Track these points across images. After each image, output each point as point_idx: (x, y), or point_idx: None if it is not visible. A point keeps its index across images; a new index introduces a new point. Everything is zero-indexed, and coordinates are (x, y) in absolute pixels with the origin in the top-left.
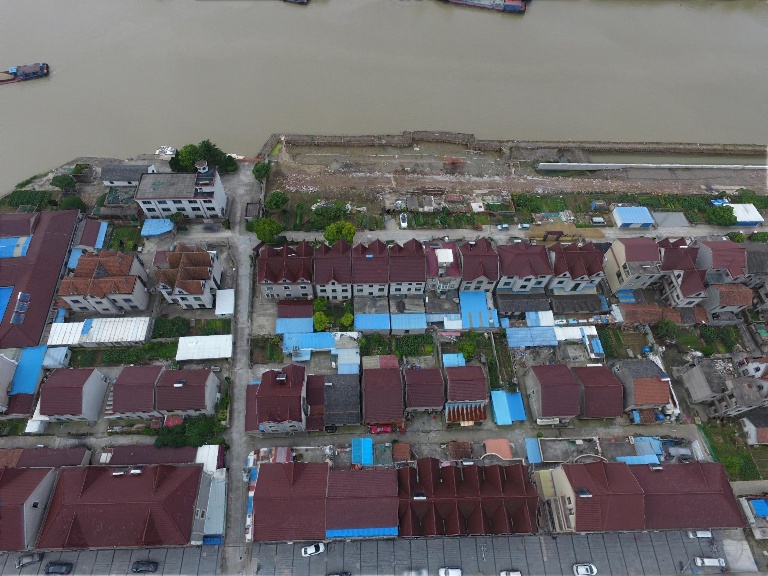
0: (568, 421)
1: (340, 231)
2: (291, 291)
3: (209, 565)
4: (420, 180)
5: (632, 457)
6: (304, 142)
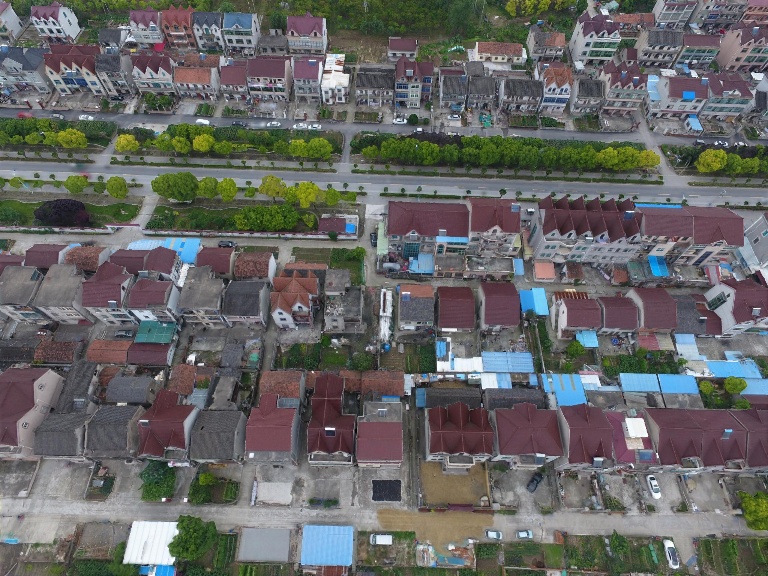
0: None
1: None
2: None
3: None
4: None
5: (457, 241)
6: None
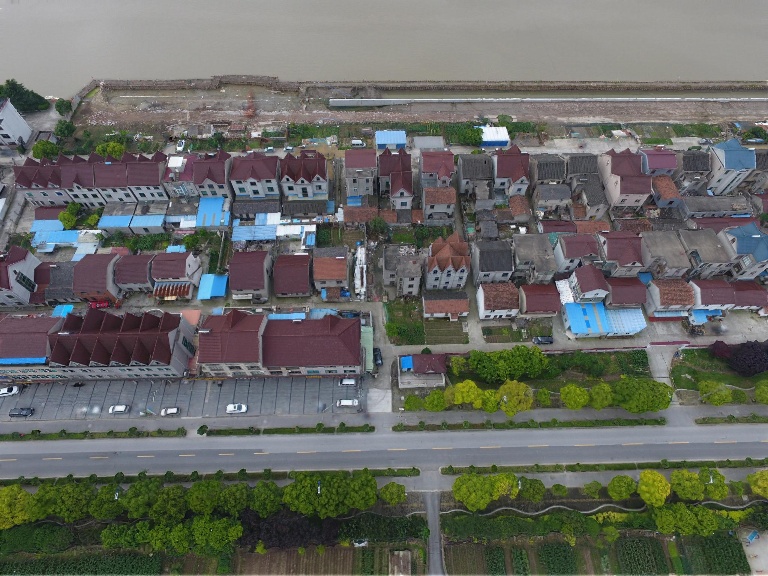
0: (267, 299)
1: (106, 149)
2: (51, 198)
3: None
4: (213, 115)
5: (282, 314)
6: (120, 86)
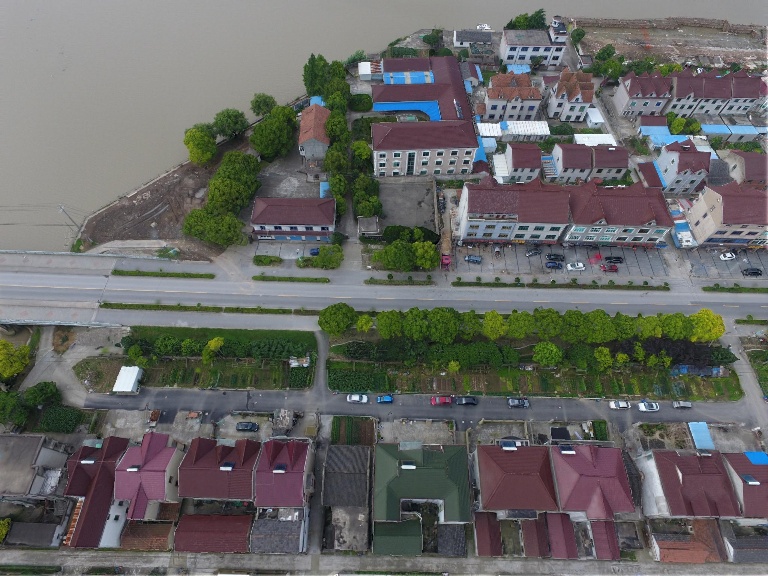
0: None
1: (671, 70)
2: (646, 108)
3: (657, 262)
4: (697, 49)
5: None
6: (590, 23)
